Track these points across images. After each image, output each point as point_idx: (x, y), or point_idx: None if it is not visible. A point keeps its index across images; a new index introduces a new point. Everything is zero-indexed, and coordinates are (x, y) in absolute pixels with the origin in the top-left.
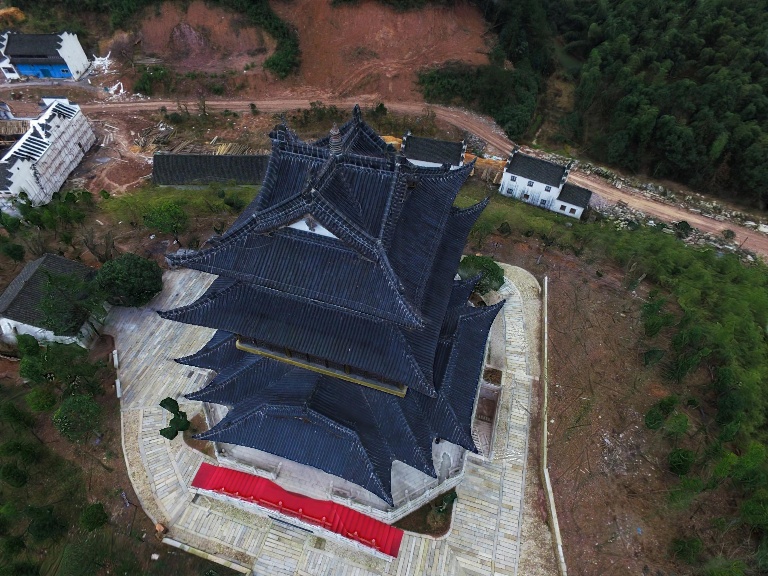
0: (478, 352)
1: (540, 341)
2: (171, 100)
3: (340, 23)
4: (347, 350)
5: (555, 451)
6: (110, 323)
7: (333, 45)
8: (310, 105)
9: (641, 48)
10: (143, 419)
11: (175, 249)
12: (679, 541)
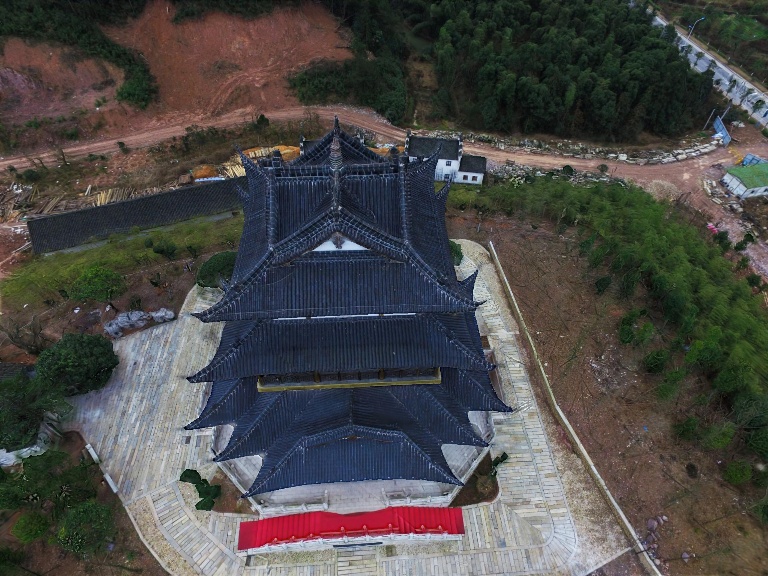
0: (472, 324)
1: (507, 299)
2: (16, 157)
3: (188, 40)
4: (392, 354)
5: (558, 389)
6: (67, 418)
7: (188, 64)
8: (185, 131)
9: (482, 21)
10: (154, 504)
11: (112, 316)
12: (676, 425)
